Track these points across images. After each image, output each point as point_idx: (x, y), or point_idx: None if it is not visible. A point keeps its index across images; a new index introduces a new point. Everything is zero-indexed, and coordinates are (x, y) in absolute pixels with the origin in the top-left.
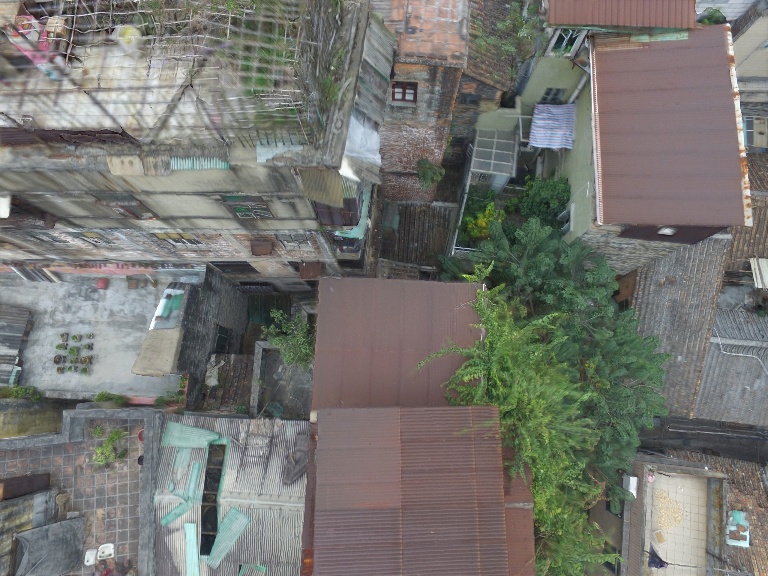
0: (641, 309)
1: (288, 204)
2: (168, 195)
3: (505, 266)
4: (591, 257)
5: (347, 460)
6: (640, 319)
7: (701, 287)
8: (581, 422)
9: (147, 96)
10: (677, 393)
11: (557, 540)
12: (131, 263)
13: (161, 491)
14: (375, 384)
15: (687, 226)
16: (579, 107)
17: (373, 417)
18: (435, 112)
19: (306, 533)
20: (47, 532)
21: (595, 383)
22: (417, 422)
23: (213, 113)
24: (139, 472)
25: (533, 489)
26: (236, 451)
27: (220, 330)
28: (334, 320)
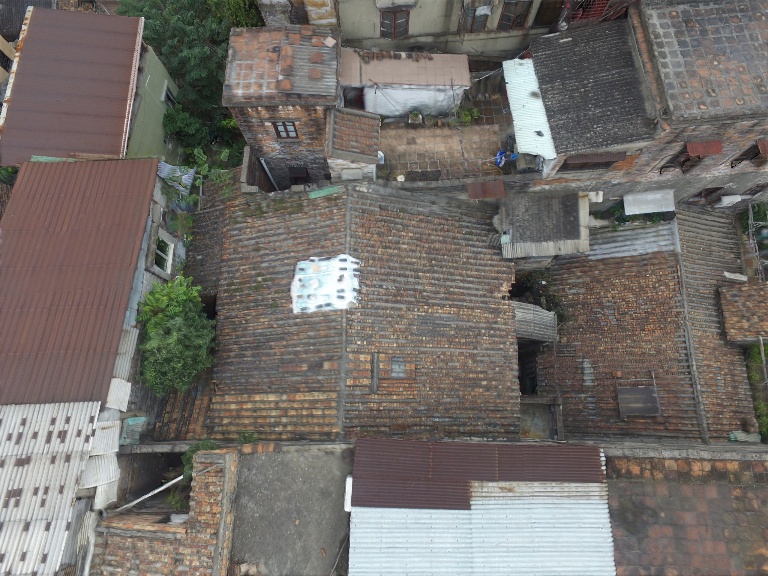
0: None
1: None
2: None
3: None
4: None
5: None
6: None
7: None
8: None
9: None
10: None
11: None
12: None
13: None
14: None
15: None
16: None
17: None
18: None
19: None
20: None
21: None
22: None
23: None
24: None
25: None
26: None
27: None
28: None
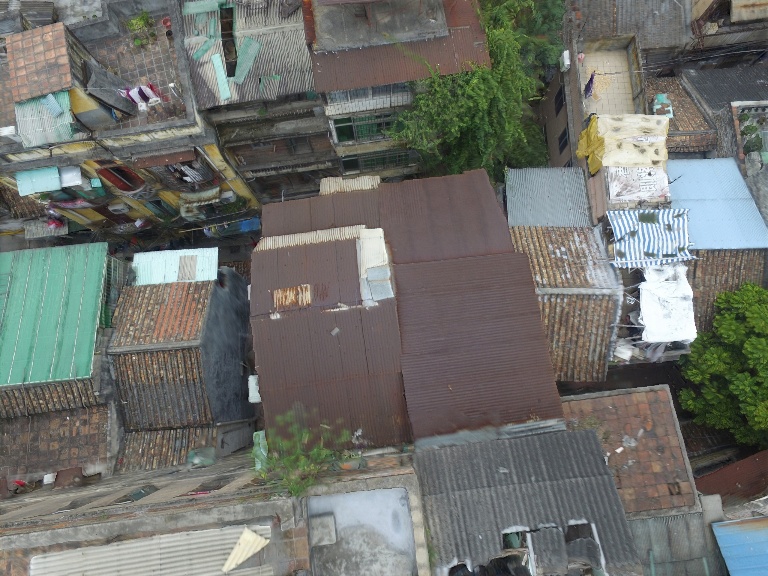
0: None
1: None
2: None
3: None
4: None
5: None
6: None
7: None
8: None
9: None
10: (600, 24)
11: None
12: None
13: (188, 37)
14: None
15: None
16: None
17: None
18: None
19: None
20: (106, 73)
21: None
22: None
23: None
24: (168, 48)
25: None
26: (241, 9)
27: None
28: None
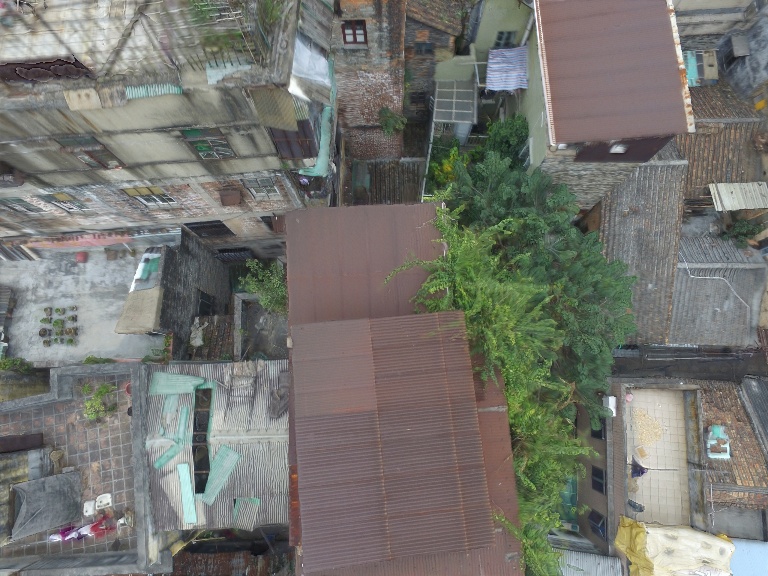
0: (609, 241)
1: (247, 137)
2: (129, 135)
3: (471, 203)
4: (553, 189)
5: (322, 370)
6: (609, 251)
7: (664, 214)
8: (544, 322)
9: (98, 34)
10: (651, 320)
11: (533, 440)
12: (107, 232)
13: (152, 436)
14: (347, 307)
15: (636, 140)
16: (530, 47)
17: (344, 328)
18: (387, 53)
19: (292, 451)
20: (43, 484)
21: (564, 302)
22: (387, 330)
23: (158, 30)
24: (130, 424)
25: (506, 392)
26: (222, 393)
27: (202, 296)
28: (303, 250)
